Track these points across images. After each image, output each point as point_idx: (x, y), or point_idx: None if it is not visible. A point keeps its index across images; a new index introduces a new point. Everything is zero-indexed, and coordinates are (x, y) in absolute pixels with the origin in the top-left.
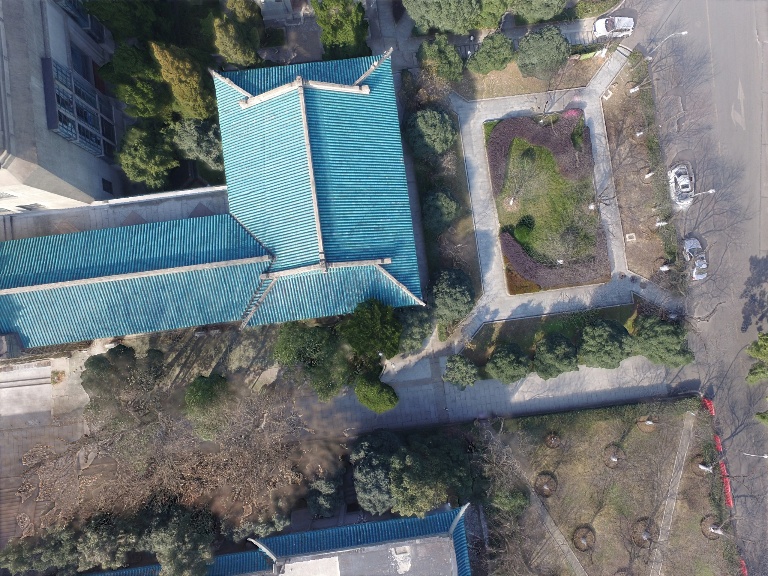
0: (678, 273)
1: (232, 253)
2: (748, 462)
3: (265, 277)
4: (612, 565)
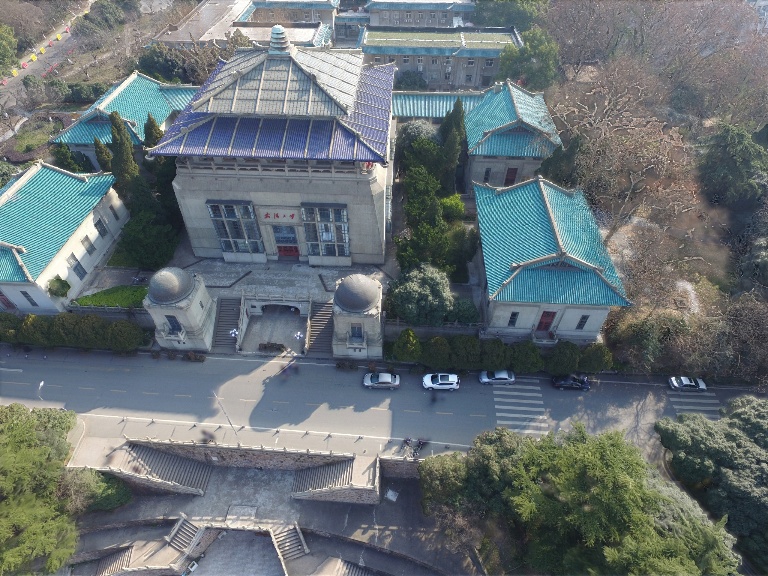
0: (4, 105)
1: (176, 92)
2: None
3: (167, 84)
4: (116, 60)
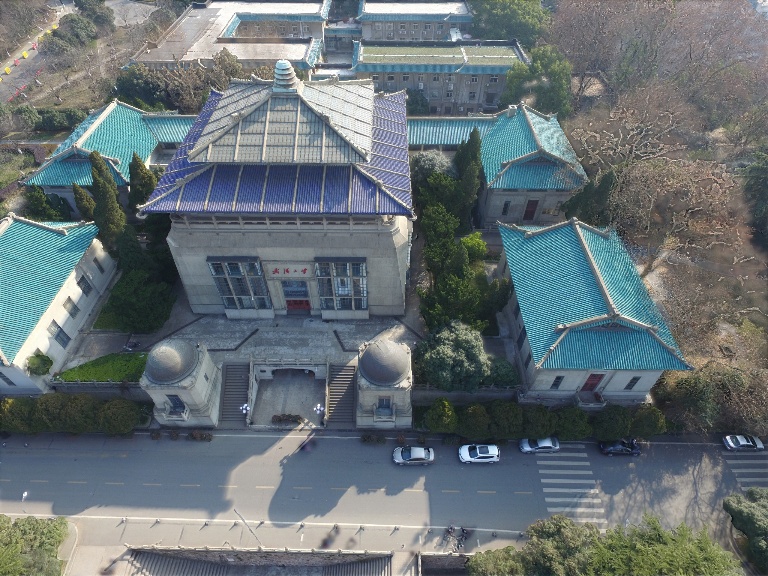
0: None
1: (161, 122)
2: (5, 97)
3: None
4: (89, 80)
